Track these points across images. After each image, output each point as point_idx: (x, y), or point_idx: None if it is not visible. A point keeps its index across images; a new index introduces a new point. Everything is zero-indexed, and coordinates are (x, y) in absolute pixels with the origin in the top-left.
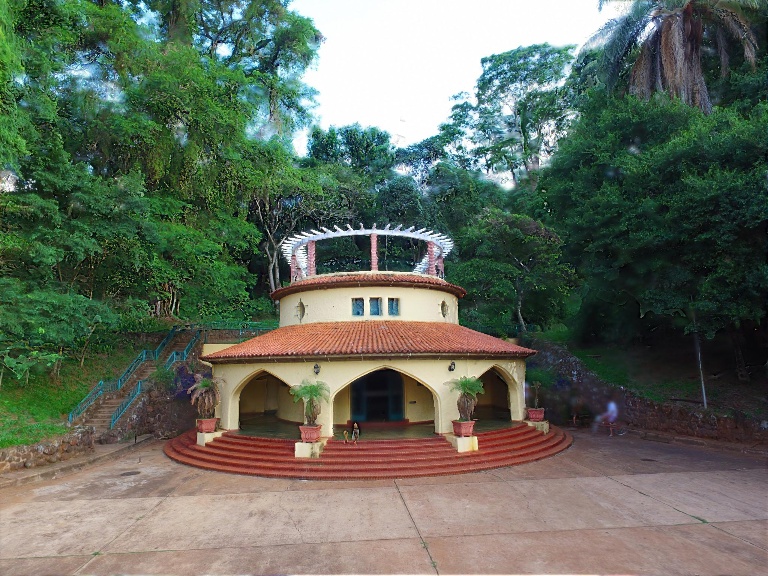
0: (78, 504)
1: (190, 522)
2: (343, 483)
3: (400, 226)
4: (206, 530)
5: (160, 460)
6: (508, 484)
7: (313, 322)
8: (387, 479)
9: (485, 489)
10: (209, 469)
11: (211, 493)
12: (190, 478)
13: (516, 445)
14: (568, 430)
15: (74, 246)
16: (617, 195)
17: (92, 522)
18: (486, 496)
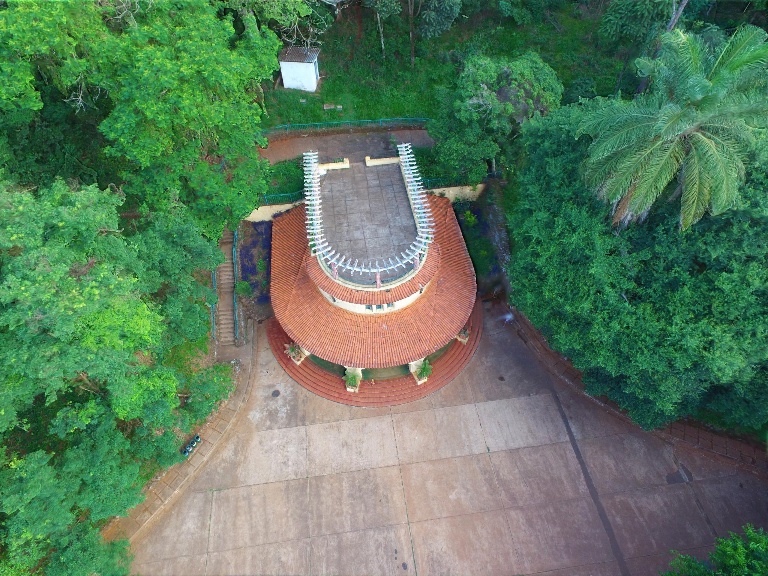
0: (277, 434)
1: (325, 453)
2: (370, 411)
3: None
4: (333, 460)
5: (279, 371)
6: (434, 413)
7: (342, 308)
8: (387, 407)
9: (425, 419)
10: (309, 391)
11: (321, 422)
12: (305, 402)
13: (446, 370)
14: (486, 310)
15: (179, 288)
16: None
17: (292, 452)
18: (424, 427)
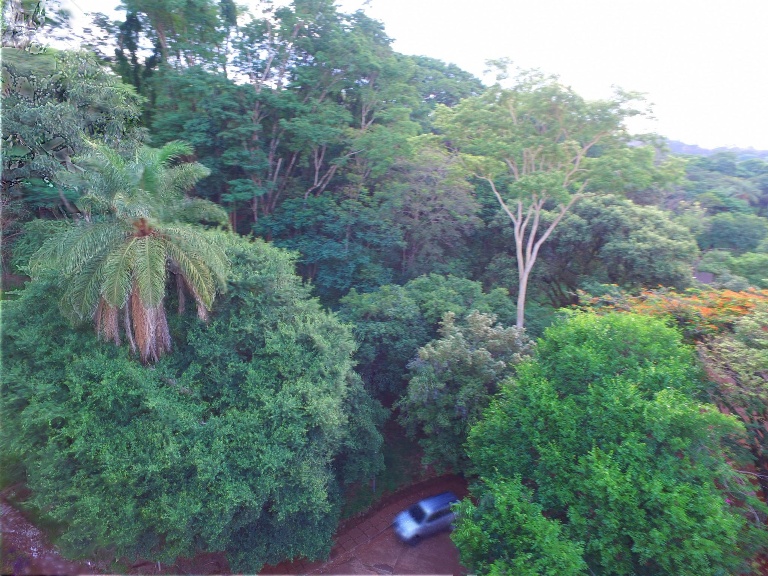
0: None
1: None
2: None
3: None
4: None
5: None
6: None
7: None
8: None
9: None
10: None
11: None
12: None
13: None
14: None
15: None
16: (98, 503)
17: None
18: None
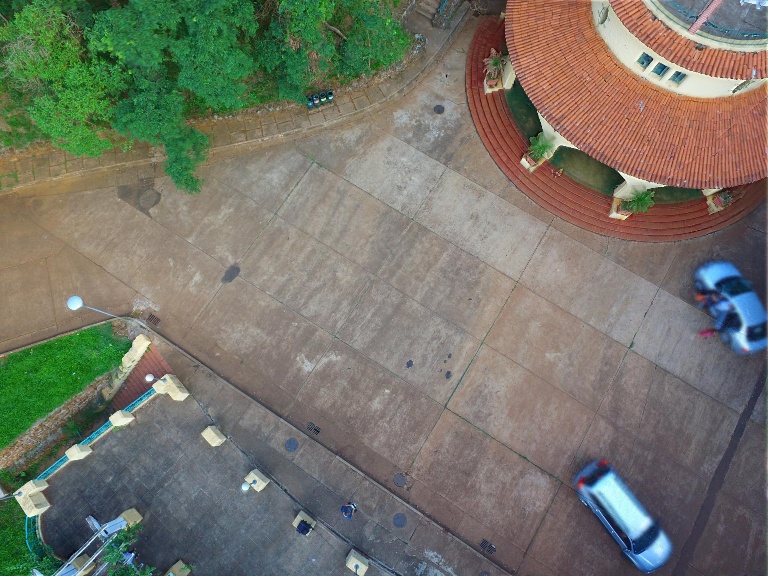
0: (411, 153)
1: (447, 209)
2: (529, 203)
3: (757, 8)
4: (450, 222)
5: (459, 86)
6: (601, 261)
7: (604, 40)
8: (552, 214)
9: (584, 259)
10: (477, 132)
11: (466, 175)
12: (464, 141)
13: (658, 225)
14: None
15: None
16: None
17: (414, 183)
18: (576, 266)
